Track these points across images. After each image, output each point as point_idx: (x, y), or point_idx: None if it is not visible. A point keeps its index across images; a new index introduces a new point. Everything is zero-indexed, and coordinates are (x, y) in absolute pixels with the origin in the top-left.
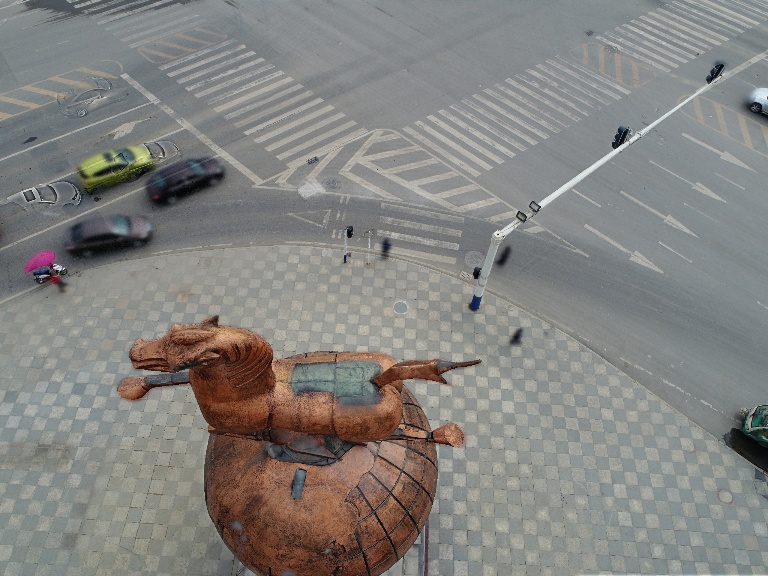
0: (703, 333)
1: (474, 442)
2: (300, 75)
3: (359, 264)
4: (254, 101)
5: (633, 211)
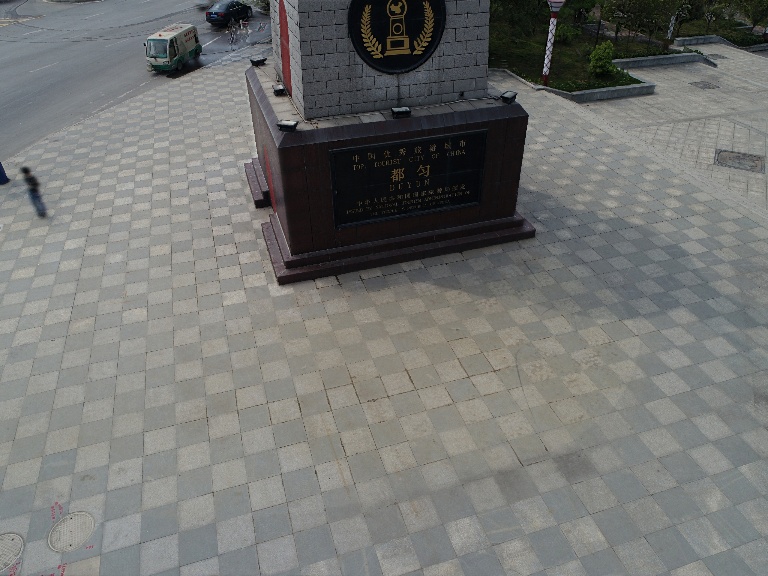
0: (64, 87)
1: (211, 153)
2: None
3: None
4: None
5: None
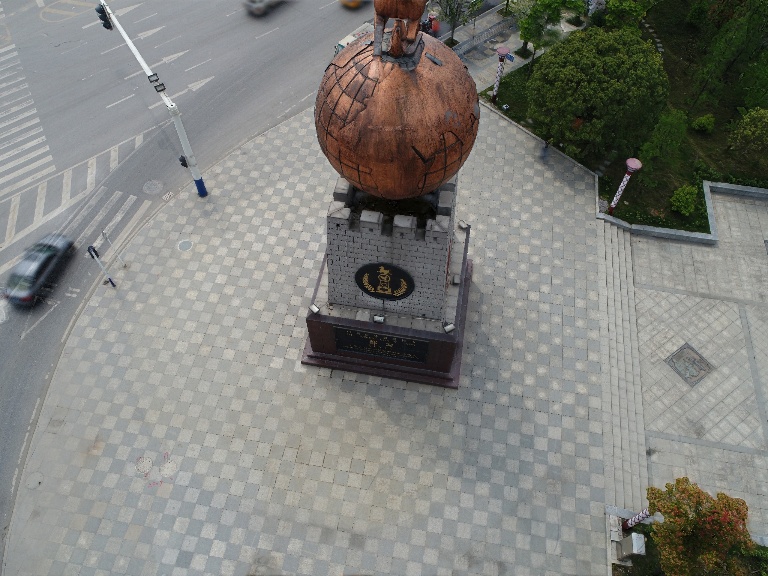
0: (271, 71)
1: (325, 212)
2: None
3: (122, 274)
4: None
5: None
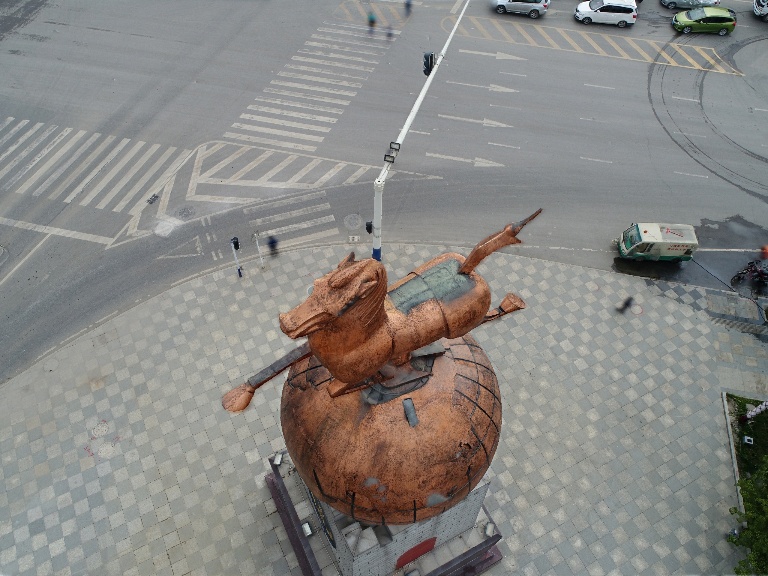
0: (557, 198)
1: None
2: (91, 124)
3: (255, 272)
4: (56, 167)
5: (456, 127)
